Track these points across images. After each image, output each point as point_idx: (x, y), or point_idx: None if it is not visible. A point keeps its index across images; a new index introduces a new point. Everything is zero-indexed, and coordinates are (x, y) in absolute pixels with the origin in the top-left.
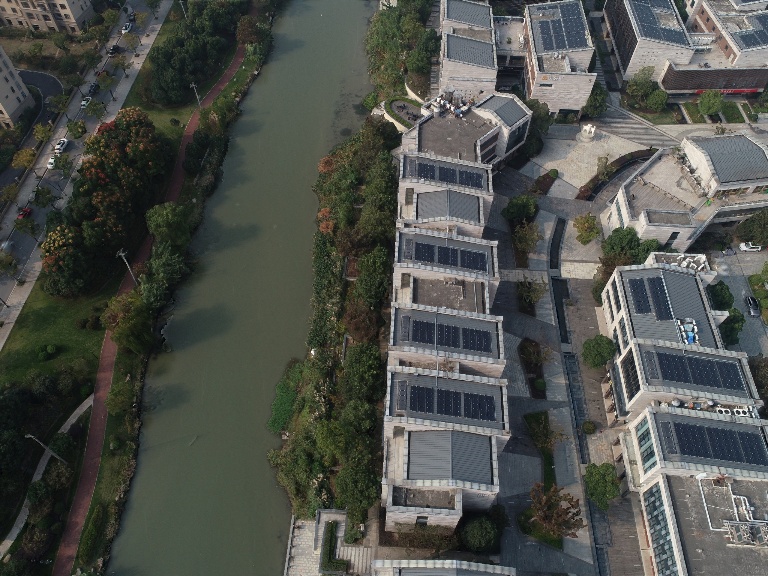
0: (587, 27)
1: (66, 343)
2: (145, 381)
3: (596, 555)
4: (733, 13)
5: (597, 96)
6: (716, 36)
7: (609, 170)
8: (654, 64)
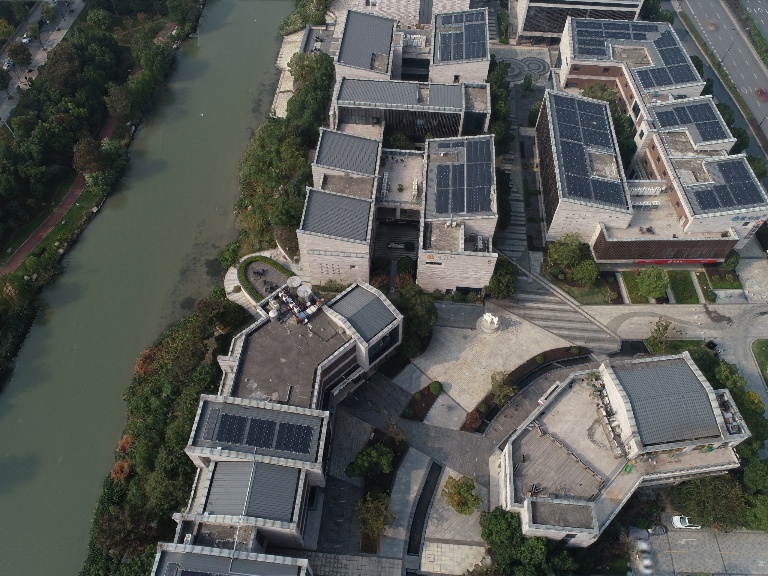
0: (494, 180)
1: None
2: None
3: None
4: (690, 154)
5: (501, 277)
6: (666, 185)
7: (505, 393)
8: (582, 226)
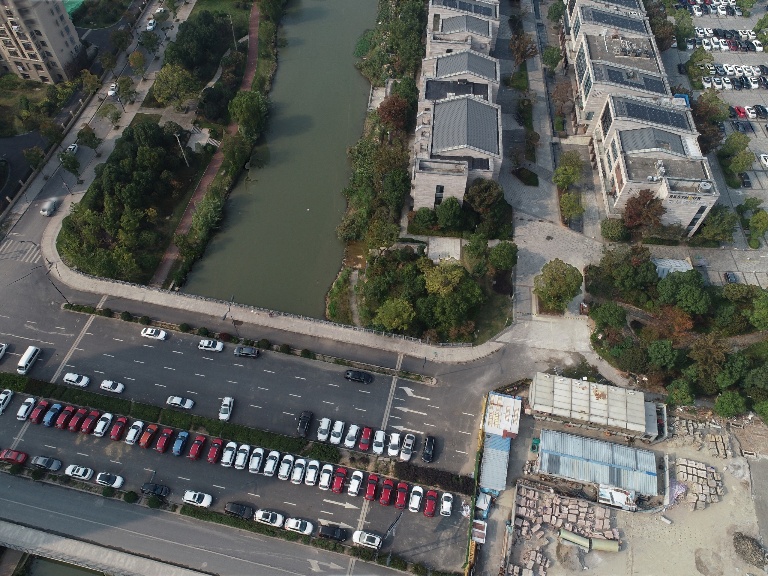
0: None
1: (228, 13)
2: (277, 35)
3: (547, 94)
4: None
5: None
6: None
7: None
8: None
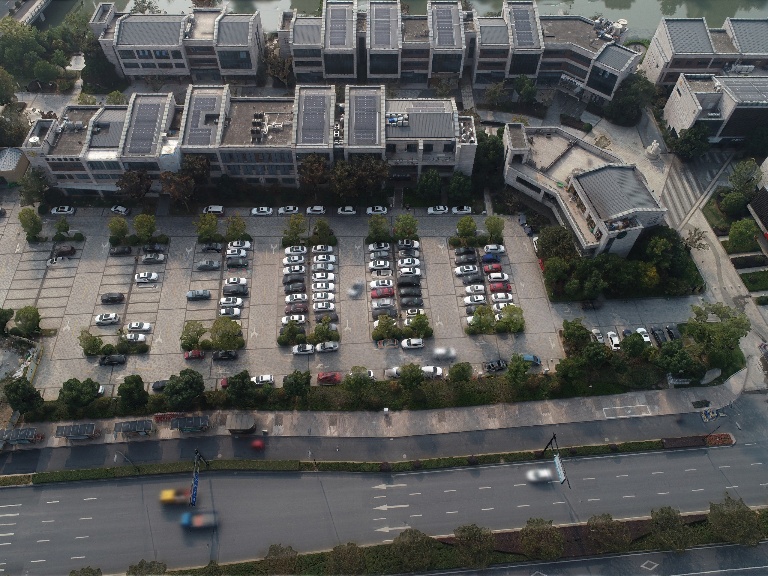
0: None
1: None
2: None
3: None
4: None
5: (689, 132)
6: None
7: None
8: None
